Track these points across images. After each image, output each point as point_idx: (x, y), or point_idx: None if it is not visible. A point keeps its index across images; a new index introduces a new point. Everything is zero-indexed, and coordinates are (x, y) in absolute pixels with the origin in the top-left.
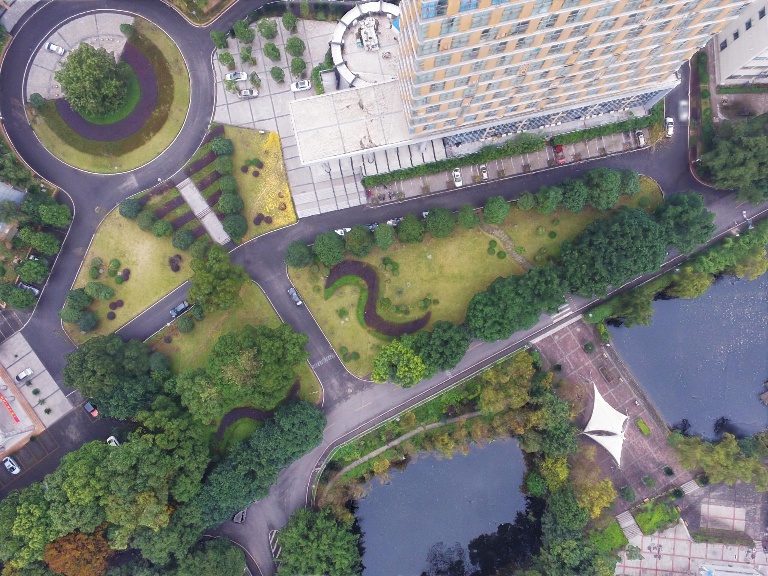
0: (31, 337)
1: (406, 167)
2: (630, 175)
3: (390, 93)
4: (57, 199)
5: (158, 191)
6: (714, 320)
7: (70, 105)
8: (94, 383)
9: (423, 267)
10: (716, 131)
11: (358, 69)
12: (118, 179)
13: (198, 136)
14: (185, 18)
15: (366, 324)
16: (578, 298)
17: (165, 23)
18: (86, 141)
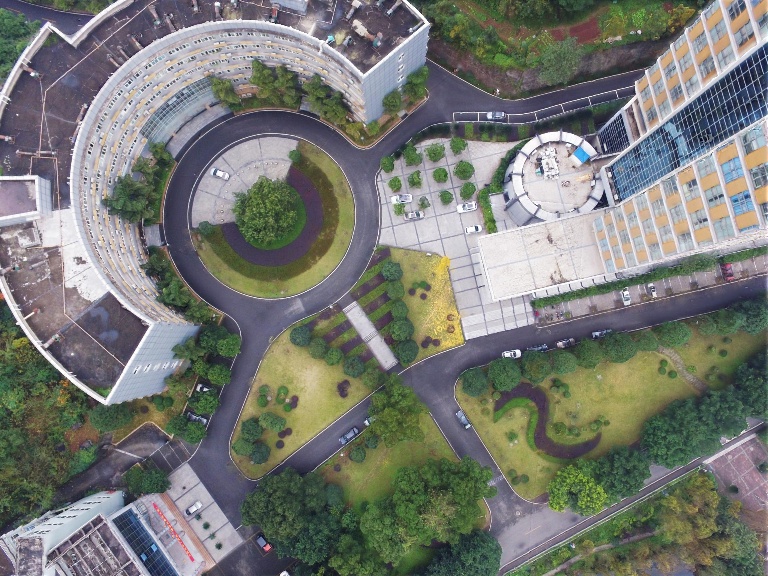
0: (199, 468)
1: (577, 288)
2: None
3: (579, 227)
4: (225, 326)
5: (326, 316)
6: None
7: (246, 237)
8: (286, 529)
9: (593, 387)
10: None
11: (538, 198)
12: (284, 304)
13: (364, 259)
14: (348, 141)
15: (536, 446)
16: (752, 418)
17: (328, 146)
18: (253, 267)
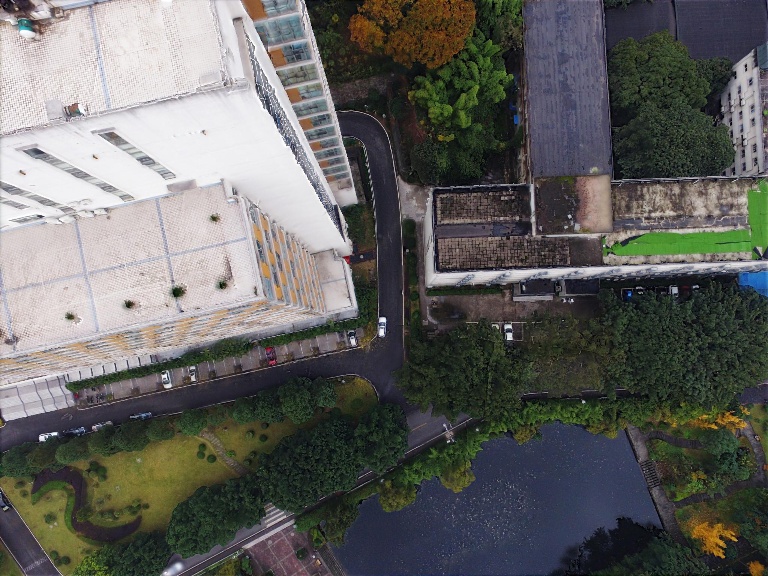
0: None
1: (108, 372)
2: (321, 391)
3: None
4: None
5: None
6: (435, 522)
7: None
8: None
9: (132, 471)
10: None
11: None
12: None
13: None
14: None
15: (74, 529)
16: None
17: None
18: None
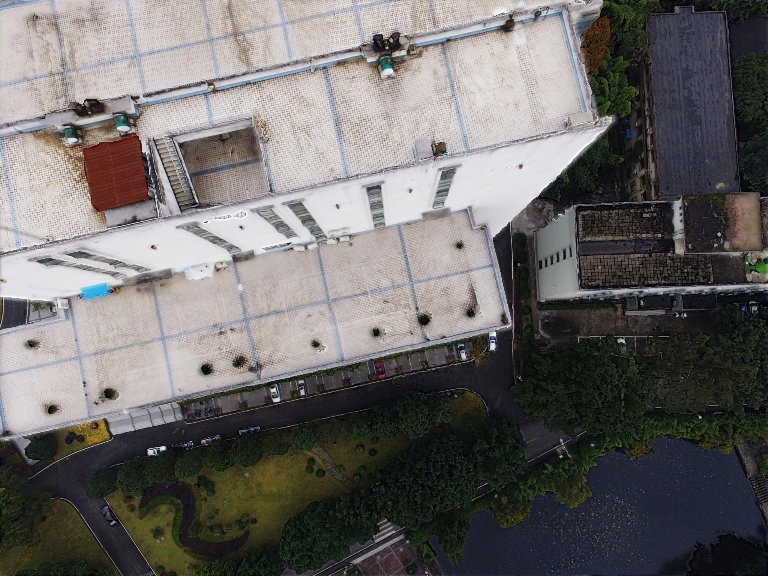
0: None
1: None
2: (439, 406)
3: None
4: None
5: None
6: (544, 537)
7: None
8: None
9: (240, 485)
10: None
11: None
12: None
13: None
14: None
15: (182, 544)
16: None
17: None
18: None
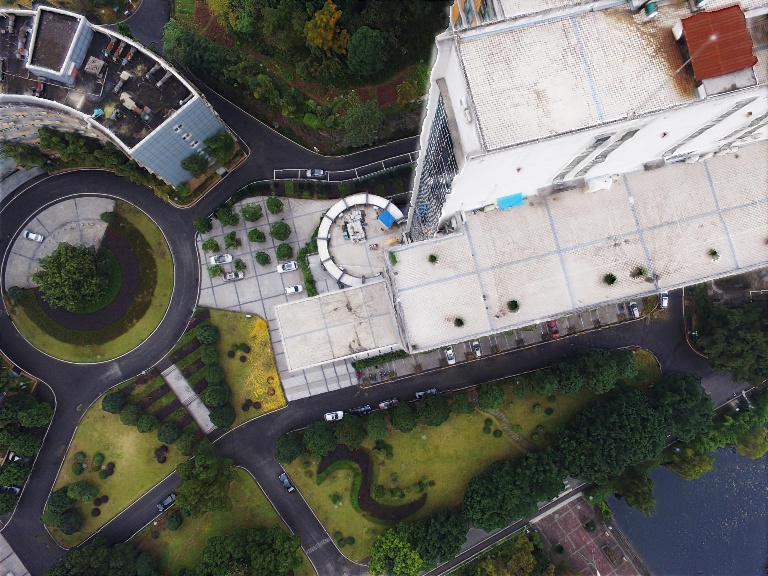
0: (12, 538)
1: (397, 349)
2: (626, 361)
3: (379, 294)
4: (38, 393)
5: (142, 380)
6: (717, 491)
7: (49, 304)
8: None
9: (418, 448)
10: (711, 310)
11: (345, 262)
12: (101, 368)
13: (183, 321)
14: None
15: (360, 509)
16: None
17: (147, 205)
18: (67, 331)
